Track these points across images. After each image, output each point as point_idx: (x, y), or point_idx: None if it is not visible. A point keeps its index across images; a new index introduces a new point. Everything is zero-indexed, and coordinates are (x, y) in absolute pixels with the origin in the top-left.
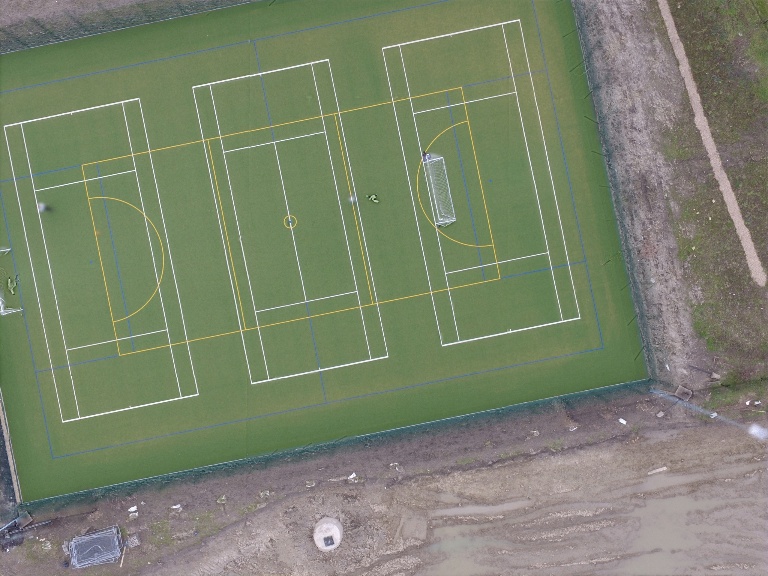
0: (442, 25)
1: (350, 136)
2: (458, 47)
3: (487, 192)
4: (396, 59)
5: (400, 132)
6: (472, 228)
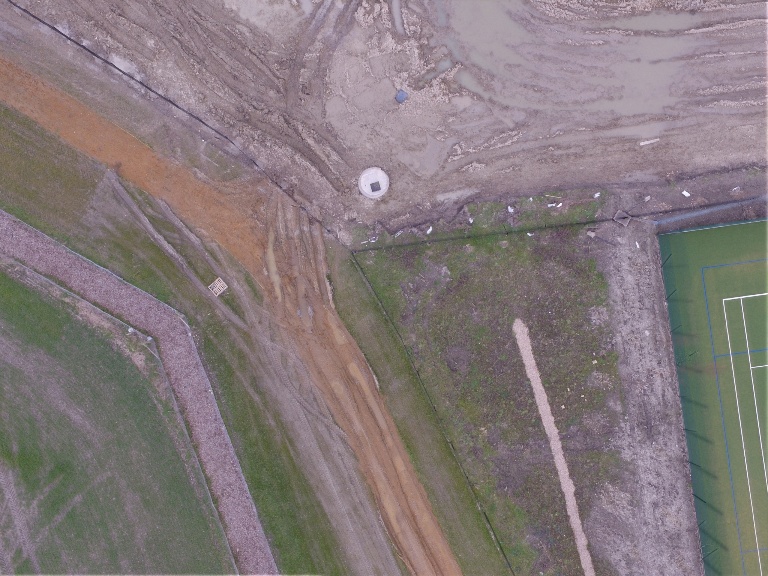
0: None
1: None
2: None
3: None
4: None
5: None
6: None
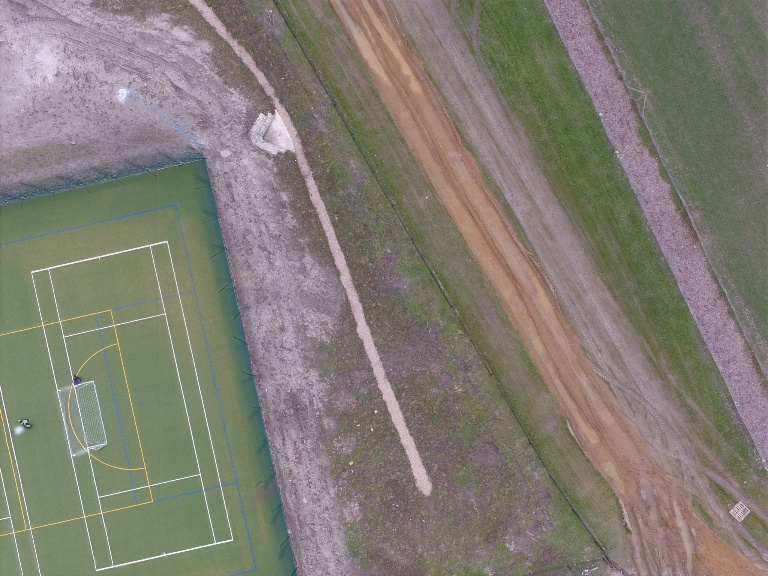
0: (90, 248)
1: (1, 361)
2: (107, 270)
3: (138, 415)
4: (45, 283)
5: (51, 356)
6: (124, 451)
